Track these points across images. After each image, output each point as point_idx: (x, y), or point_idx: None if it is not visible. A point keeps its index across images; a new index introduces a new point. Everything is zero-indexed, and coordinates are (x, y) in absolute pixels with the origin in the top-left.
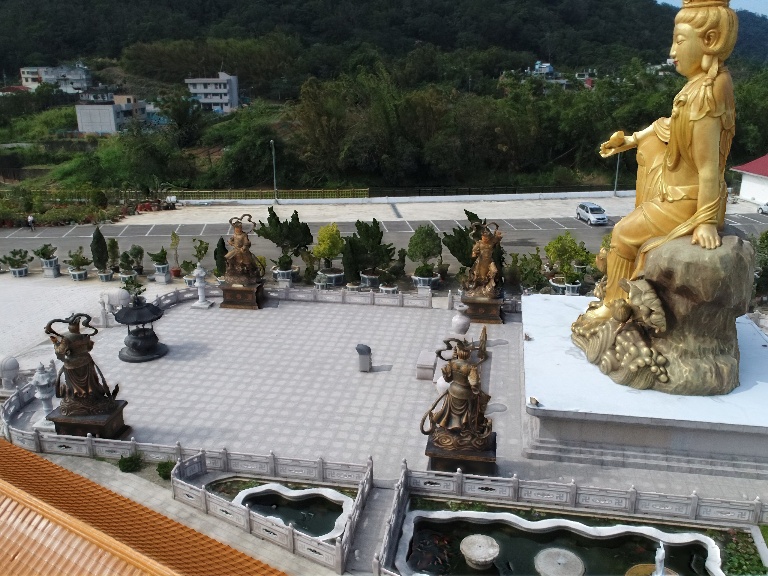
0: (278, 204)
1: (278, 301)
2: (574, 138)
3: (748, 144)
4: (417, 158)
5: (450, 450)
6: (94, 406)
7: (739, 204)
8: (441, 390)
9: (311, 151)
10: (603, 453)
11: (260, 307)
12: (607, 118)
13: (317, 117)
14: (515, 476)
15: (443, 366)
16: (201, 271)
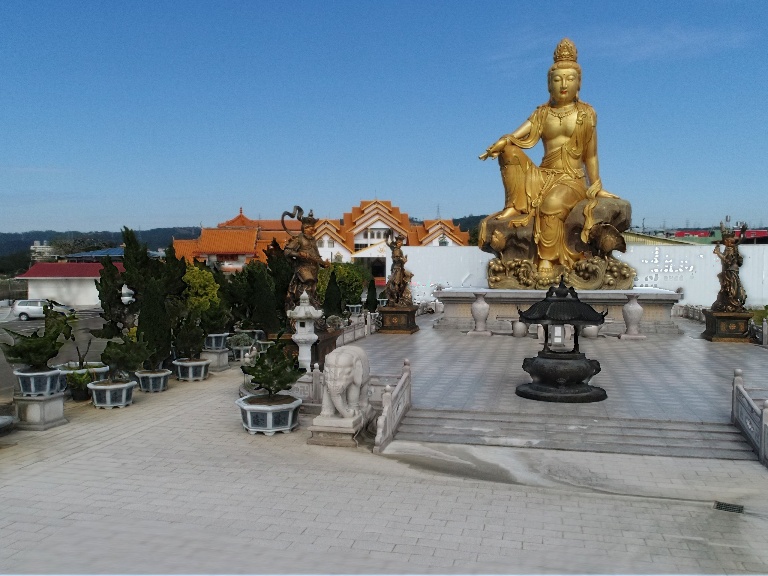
0: None
1: None
2: None
3: None
4: None
5: None
6: None
7: None
8: None
9: None
10: None
11: None
12: None
13: None
14: None
15: None
16: None
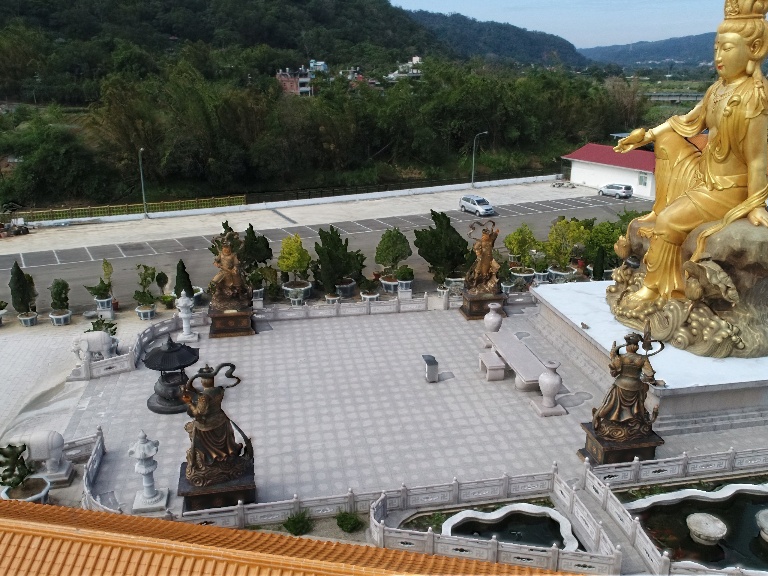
0: (149, 218)
1: (267, 323)
2: (390, 134)
3: (533, 134)
4: (244, 160)
5: (622, 441)
6: (233, 469)
7: (577, 188)
8: (549, 387)
9: (128, 158)
10: (713, 420)
11: (255, 332)
12: (419, 114)
13: (128, 121)
14: (685, 454)
15: (548, 364)
16: (187, 300)
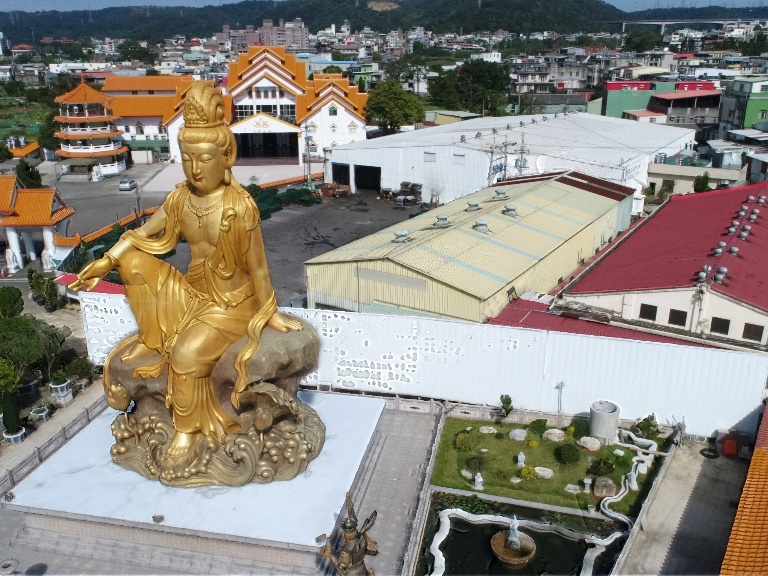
0: None
1: None
2: None
3: None
4: None
5: None
6: None
7: None
8: None
9: None
10: None
11: None
12: None
13: None
14: None
15: None
16: None
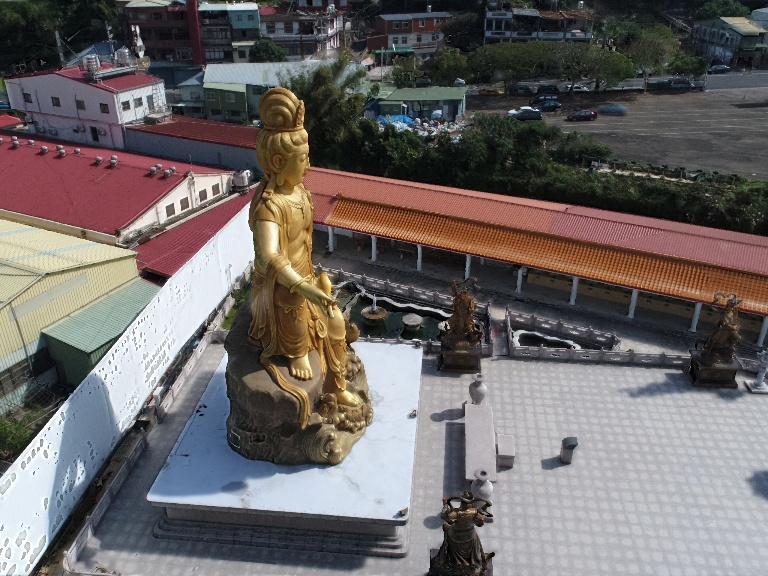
0: None
1: None
2: None
3: None
4: None
5: None
6: None
7: None
8: None
9: None
10: None
11: None
12: None
13: None
14: None
15: None
16: None
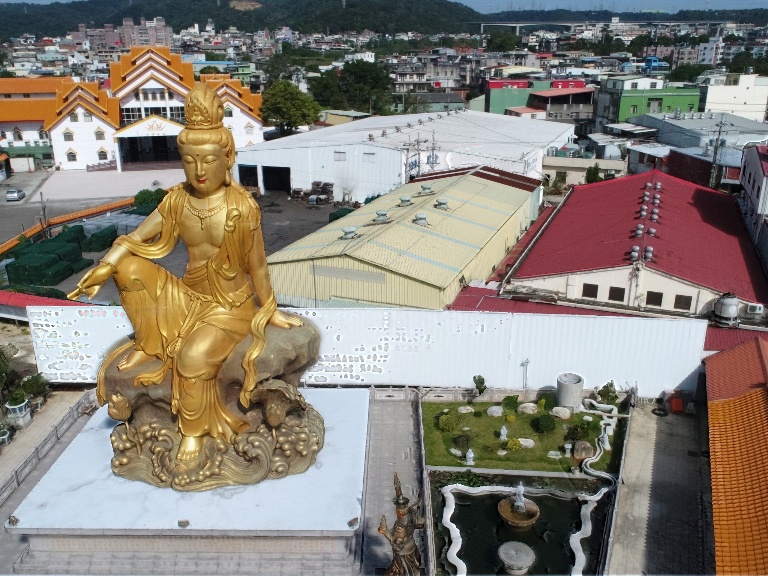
0: None
1: None
2: None
3: None
4: None
5: None
6: None
7: None
8: None
9: None
10: None
11: None
12: None
13: None
14: None
15: None
16: None
